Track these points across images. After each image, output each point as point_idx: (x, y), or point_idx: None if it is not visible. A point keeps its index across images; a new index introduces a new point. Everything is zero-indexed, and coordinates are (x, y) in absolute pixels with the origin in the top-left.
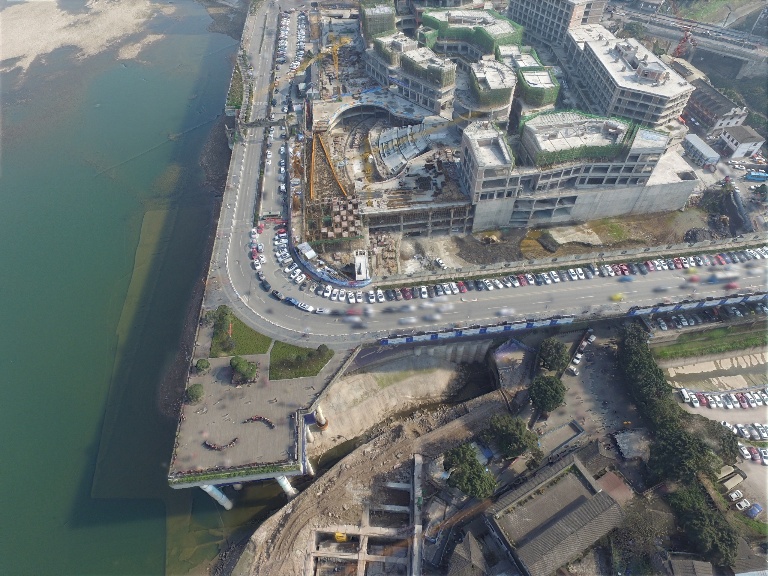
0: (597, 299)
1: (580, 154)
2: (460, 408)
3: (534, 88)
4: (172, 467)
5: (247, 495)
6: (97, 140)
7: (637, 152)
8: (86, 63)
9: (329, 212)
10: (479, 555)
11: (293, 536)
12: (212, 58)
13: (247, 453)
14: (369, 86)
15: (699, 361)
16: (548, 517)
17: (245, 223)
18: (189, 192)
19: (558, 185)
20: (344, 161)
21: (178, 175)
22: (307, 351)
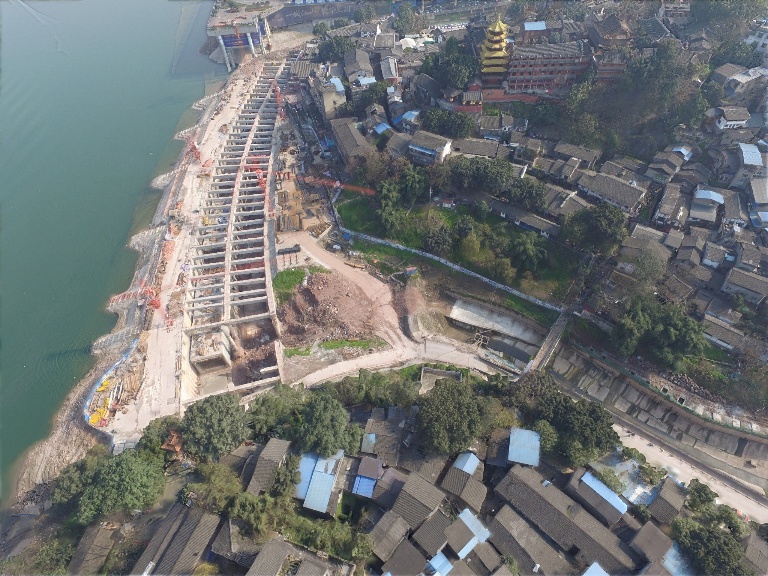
0: None
1: None
2: None
3: None
4: None
5: None
6: None
7: None
8: None
9: None
10: None
11: None
12: None
13: None
14: None
15: None
16: None
17: None
18: None
19: None
20: None
21: None
22: (261, 6)
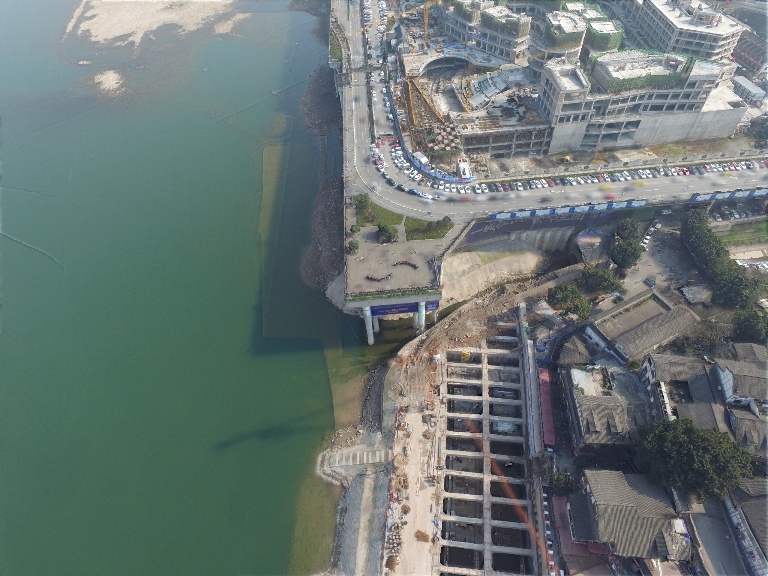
0: (663, 191)
1: (645, 82)
2: (551, 275)
3: (601, 33)
4: (347, 290)
5: (384, 336)
6: (211, 96)
7: (695, 79)
8: (188, 37)
9: (431, 134)
10: (583, 348)
11: None
12: (296, 31)
13: (400, 283)
14: (449, 42)
15: (749, 250)
16: (635, 325)
17: (364, 141)
18: (297, 133)
19: (625, 111)
20: (432, 103)
21: (285, 121)
22: None
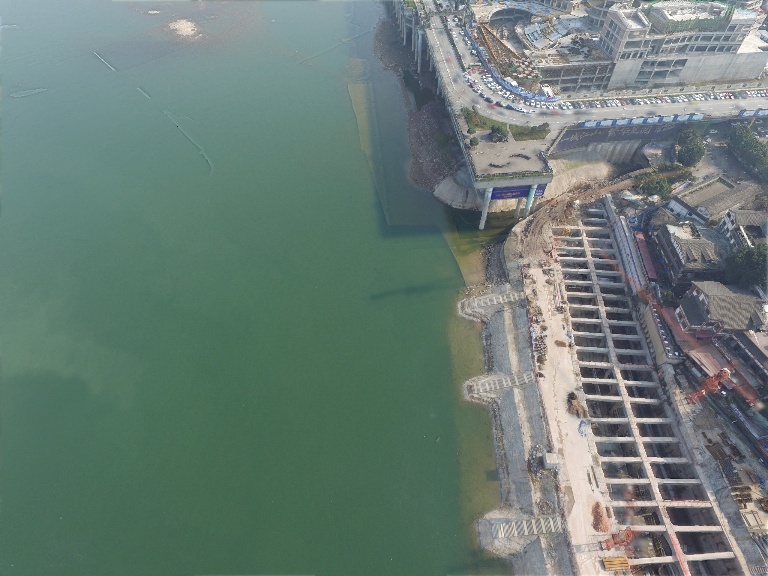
0: (715, 110)
1: (694, 25)
2: (625, 177)
3: None
4: (476, 173)
5: (491, 224)
6: (286, 42)
7: (735, 23)
8: None
9: (512, 66)
10: None
11: (540, 227)
12: None
13: (518, 169)
14: None
15: None
16: (709, 198)
17: (456, 71)
18: (375, 74)
19: (675, 50)
20: None
21: (361, 64)
22: None
